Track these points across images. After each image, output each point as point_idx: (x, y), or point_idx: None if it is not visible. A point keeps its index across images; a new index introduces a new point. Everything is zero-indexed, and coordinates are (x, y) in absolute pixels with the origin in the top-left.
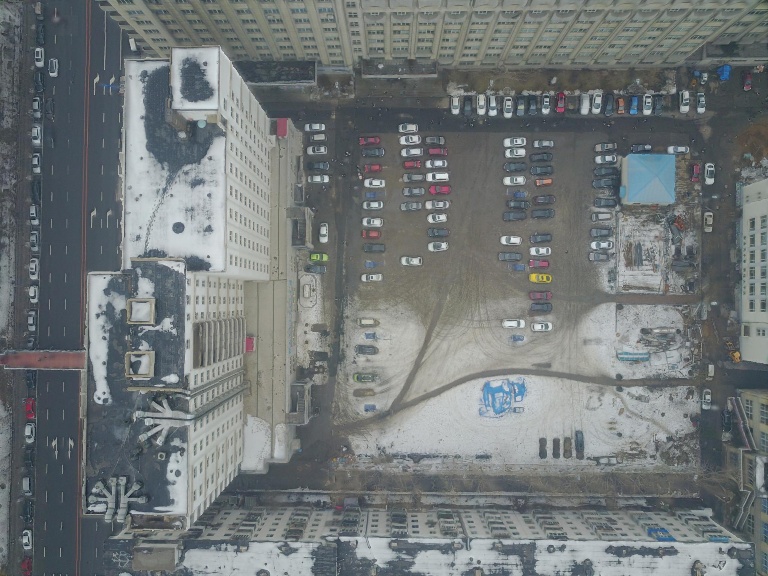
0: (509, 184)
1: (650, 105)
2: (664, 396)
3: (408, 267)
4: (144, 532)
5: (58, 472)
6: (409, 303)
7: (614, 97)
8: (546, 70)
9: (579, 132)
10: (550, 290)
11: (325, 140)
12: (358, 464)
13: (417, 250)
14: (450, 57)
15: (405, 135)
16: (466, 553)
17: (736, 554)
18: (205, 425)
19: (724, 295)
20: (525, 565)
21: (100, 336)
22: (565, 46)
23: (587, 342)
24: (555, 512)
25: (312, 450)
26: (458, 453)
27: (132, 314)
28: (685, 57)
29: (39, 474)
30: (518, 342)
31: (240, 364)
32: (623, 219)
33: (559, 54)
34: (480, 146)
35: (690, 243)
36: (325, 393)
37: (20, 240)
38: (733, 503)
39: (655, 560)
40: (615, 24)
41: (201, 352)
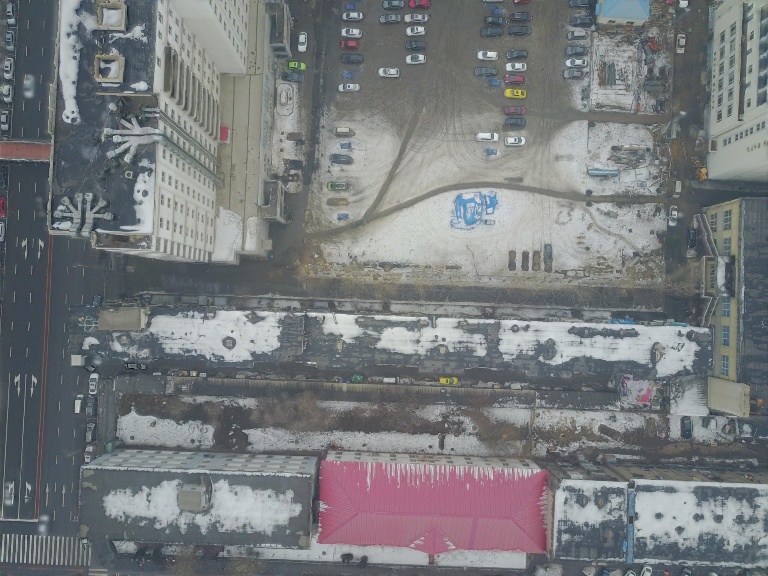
0: None
1: None
2: (632, 212)
3: (385, 79)
4: (111, 303)
5: (27, 273)
6: (385, 115)
7: None
8: None
9: None
10: (524, 106)
11: None
12: (329, 271)
13: (395, 63)
14: None
15: None
16: (431, 331)
17: (694, 337)
18: (174, 166)
19: (694, 116)
20: (489, 344)
21: (71, 56)
22: None
23: (559, 158)
24: None
25: (284, 257)
26: (429, 263)
27: (103, 21)
28: None
29: (8, 274)
30: (491, 156)
31: (214, 153)
32: (598, 39)
33: None
34: None
35: (662, 64)
36: (299, 201)
37: None
38: (695, 318)
39: (616, 341)
40: None
41: (172, 81)
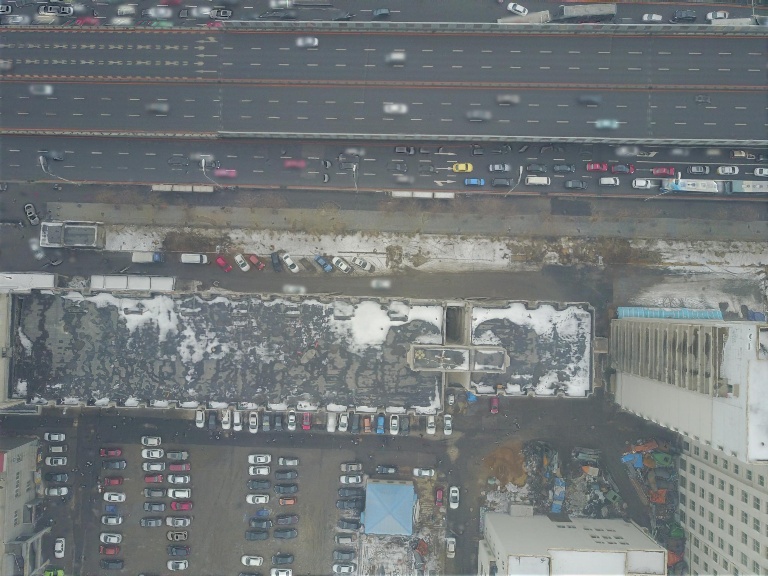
0: (251, 503)
1: (396, 426)
2: None
3: None
4: None
5: None
6: None
7: None
8: None
9: (326, 449)
10: None
11: (64, 451)
12: None
13: (157, 567)
14: None
15: (147, 449)
16: None
17: None
18: None
19: None
20: None
21: None
22: None
23: None
24: None
25: None
26: None
27: None
28: None
29: None
30: None
31: None
32: (367, 541)
33: None
34: (225, 460)
35: (433, 567)
36: None
37: None
38: None
39: None
40: None
41: None
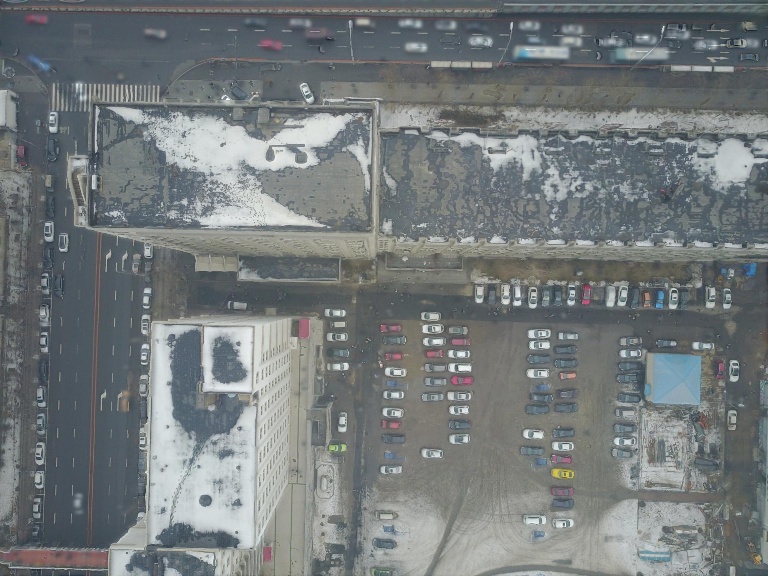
0: (533, 377)
1: (676, 300)
2: None
3: (428, 459)
4: None
5: None
6: (429, 495)
7: (640, 289)
8: (572, 260)
9: (604, 324)
10: (572, 485)
11: (345, 327)
12: None
13: (438, 441)
14: (477, 253)
15: (428, 324)
16: None
17: None
18: None
19: (746, 494)
20: None
21: None
22: (595, 253)
23: (608, 539)
24: None
25: None
26: None
27: None
28: (714, 259)
29: None
30: (539, 538)
31: (257, 574)
32: (647, 414)
33: None
34: (504, 336)
35: (713, 440)
36: None
37: (26, 422)
38: None
39: None
40: None
41: None
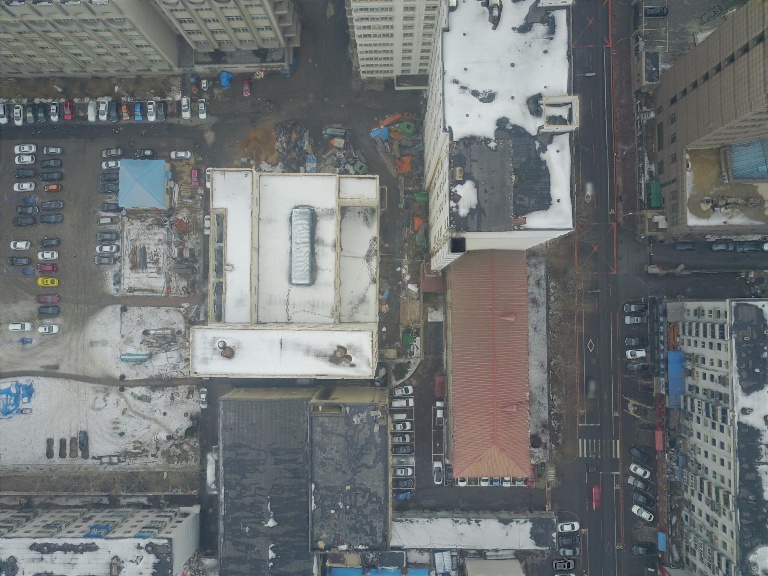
0: (18, 190)
1: (152, 111)
2: (166, 396)
3: None
4: None
5: None
6: None
7: (122, 104)
8: (57, 78)
9: (89, 138)
10: (58, 293)
11: None
12: None
13: None
14: None
15: None
16: None
17: (153, 549)
18: None
19: None
20: None
21: None
22: (34, 55)
23: (93, 344)
24: (53, 511)
25: None
26: None
27: None
28: (168, 64)
29: None
30: (27, 345)
31: None
32: (129, 223)
33: (44, 63)
34: None
35: (192, 246)
36: None
37: None
38: None
39: (76, 556)
40: (36, 34)
41: None
